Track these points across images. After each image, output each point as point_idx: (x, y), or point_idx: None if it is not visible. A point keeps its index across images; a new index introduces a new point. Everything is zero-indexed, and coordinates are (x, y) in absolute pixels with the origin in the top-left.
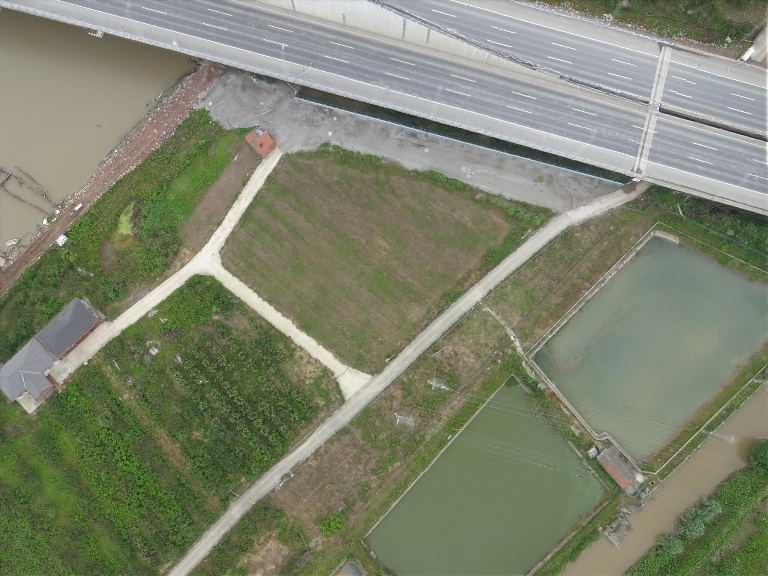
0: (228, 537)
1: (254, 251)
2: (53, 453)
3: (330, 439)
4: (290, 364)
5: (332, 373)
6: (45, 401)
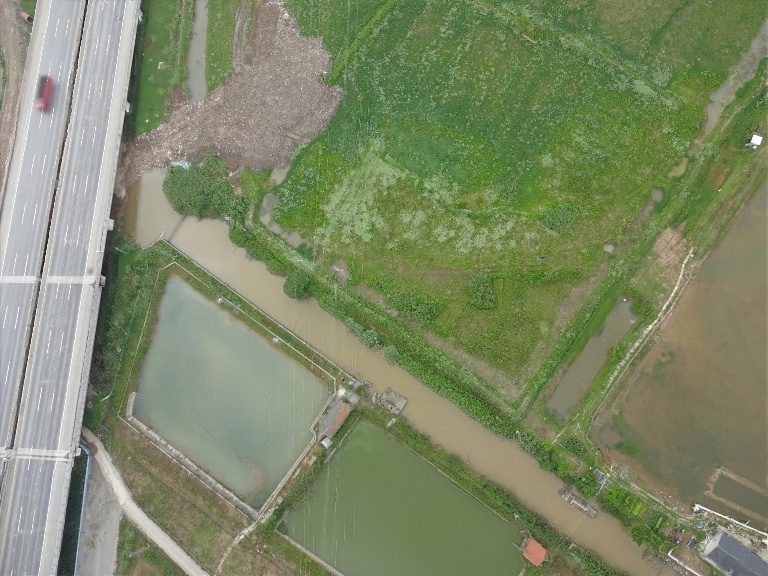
0: None
1: None
2: None
3: None
4: None
5: None
6: None
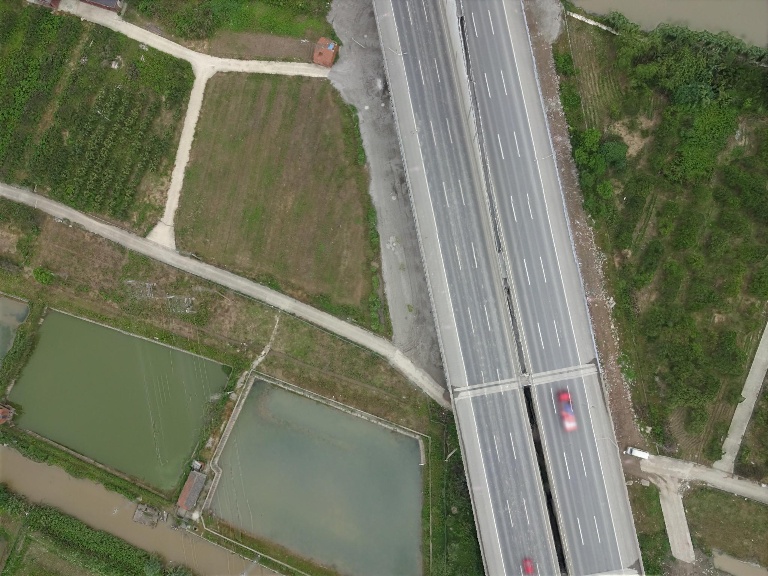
0: (2, 200)
1: (232, 99)
2: (4, 34)
3: (111, 241)
4: (154, 178)
5: (162, 215)
6: (40, 6)
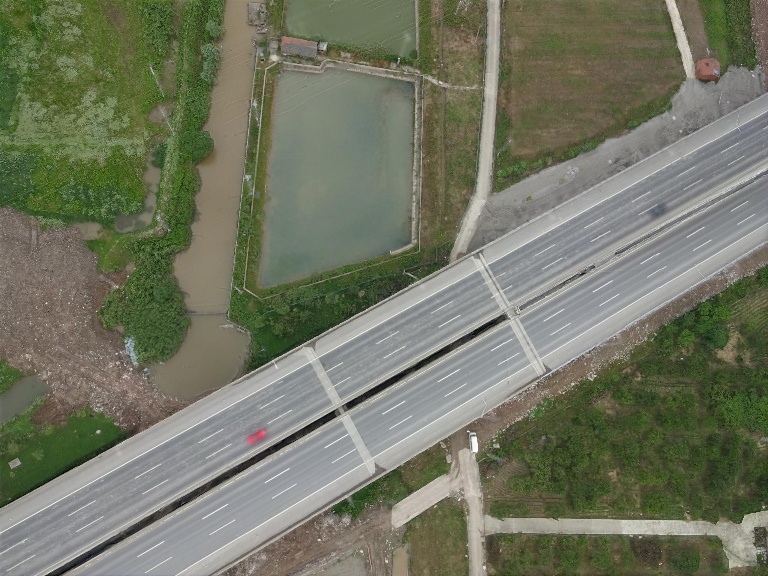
0: None
1: (642, 2)
2: None
3: None
4: None
5: None
6: None
